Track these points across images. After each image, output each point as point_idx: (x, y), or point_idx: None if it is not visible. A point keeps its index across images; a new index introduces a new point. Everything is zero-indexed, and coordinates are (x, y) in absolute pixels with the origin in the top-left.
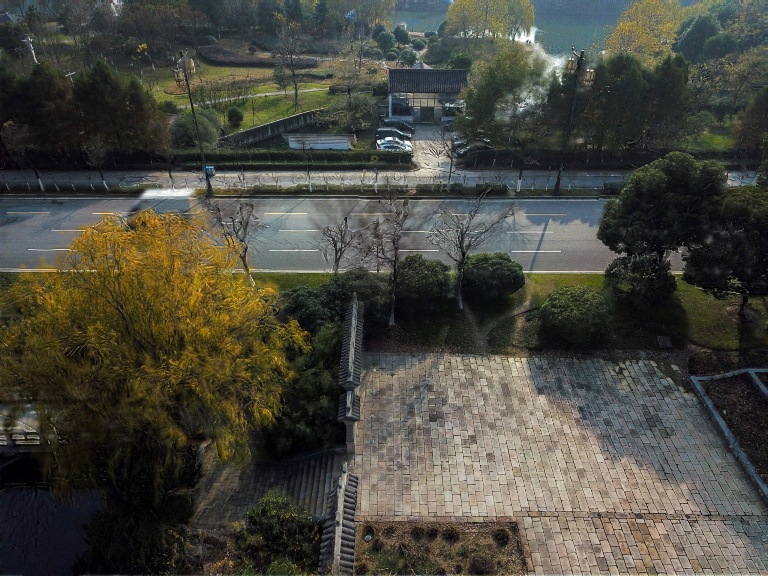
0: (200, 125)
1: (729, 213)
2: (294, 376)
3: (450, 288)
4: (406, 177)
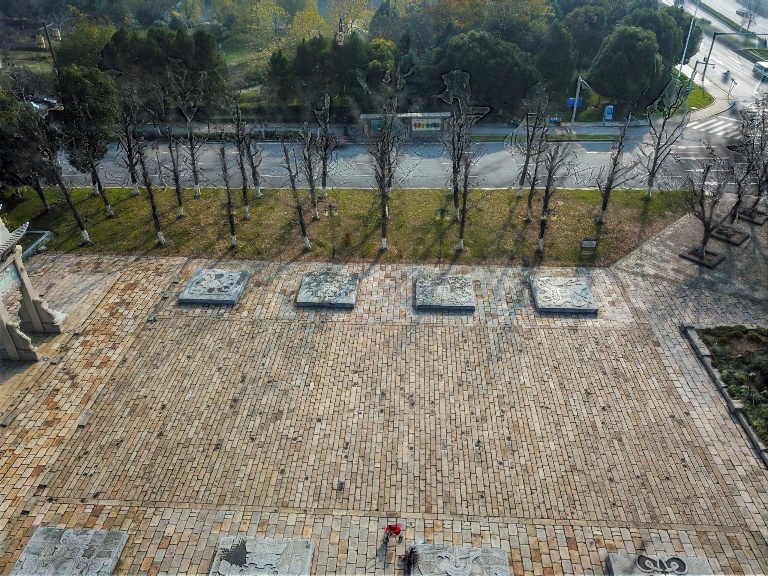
0: None
1: None
2: None
3: None
4: None
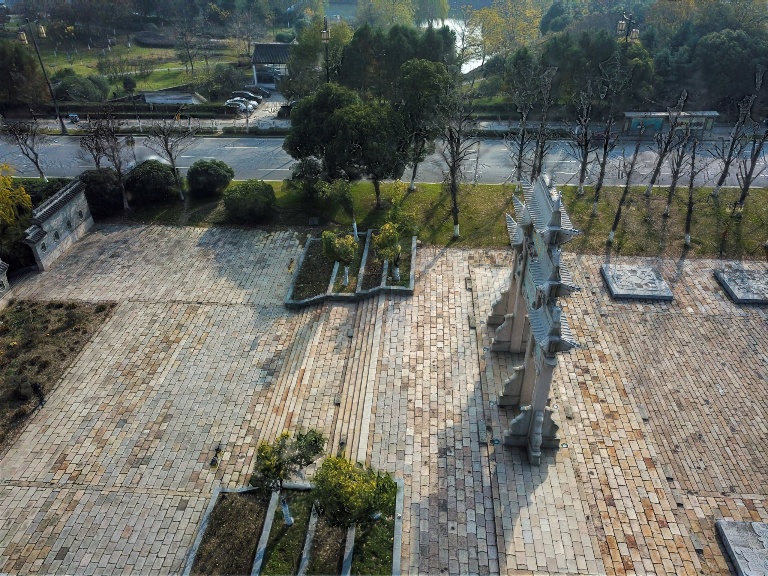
0: (80, 85)
1: (335, 121)
2: (14, 222)
3: (169, 182)
4: (213, 121)
